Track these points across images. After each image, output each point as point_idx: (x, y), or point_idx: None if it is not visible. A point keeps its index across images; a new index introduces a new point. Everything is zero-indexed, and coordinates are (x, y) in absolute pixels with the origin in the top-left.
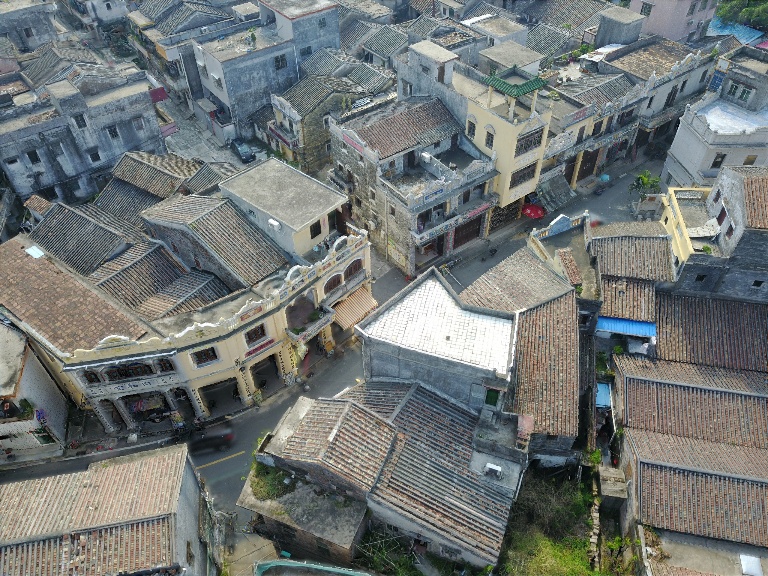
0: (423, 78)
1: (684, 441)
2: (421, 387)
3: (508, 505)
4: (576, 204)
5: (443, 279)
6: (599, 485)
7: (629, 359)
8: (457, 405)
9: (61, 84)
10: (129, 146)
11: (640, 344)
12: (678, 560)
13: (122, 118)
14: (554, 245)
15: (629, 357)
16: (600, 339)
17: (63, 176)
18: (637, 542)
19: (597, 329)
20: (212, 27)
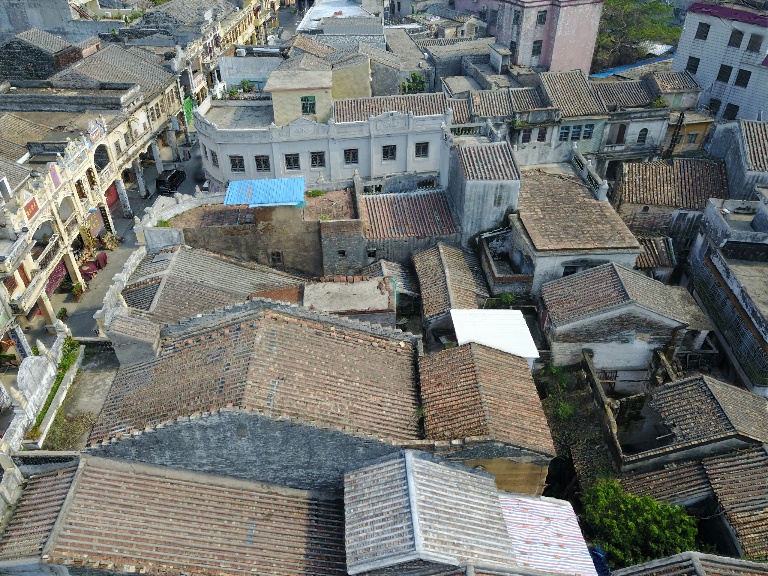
0: None
1: None
2: None
3: None
4: None
5: None
6: None
7: None
8: None
9: None
10: None
11: None
12: None
13: None
14: None
15: None
16: None
17: None
18: (160, 2)
19: None
20: None
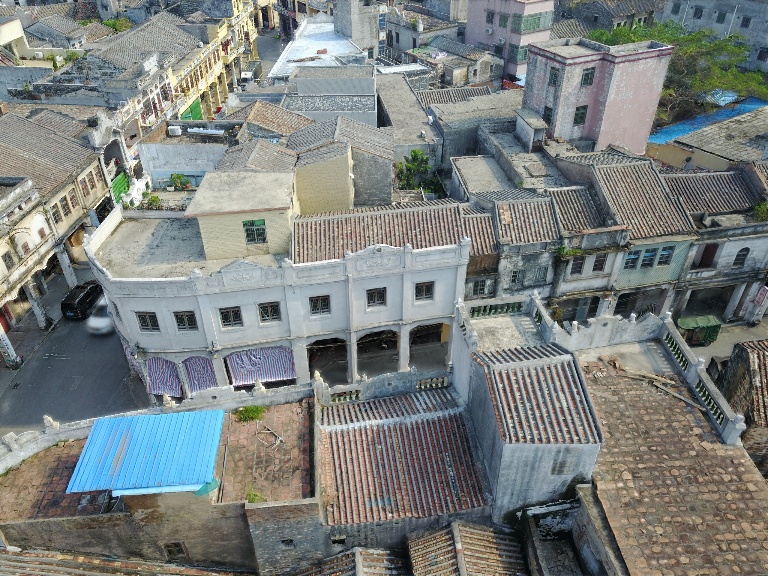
0: None
1: None
2: None
3: (140, 7)
4: None
5: None
6: None
7: None
8: None
9: None
10: None
11: None
12: None
13: None
14: None
15: None
16: None
17: None
18: (121, 29)
19: None
20: None
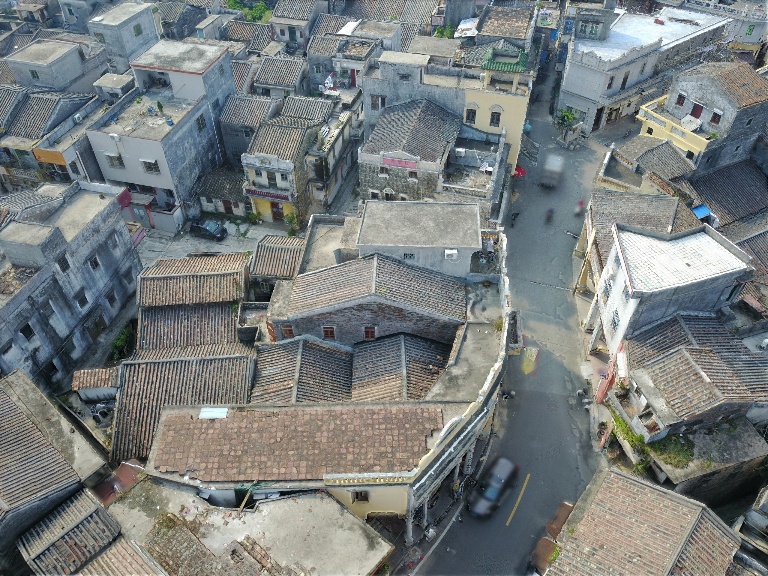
0: (402, 86)
1: None
2: (682, 315)
3: None
4: None
5: (633, 227)
6: None
7: None
8: (703, 316)
9: (13, 229)
10: (109, 272)
11: None
12: None
13: (98, 241)
14: None
15: None
16: None
17: (58, 341)
18: None
19: None
20: (82, 112)
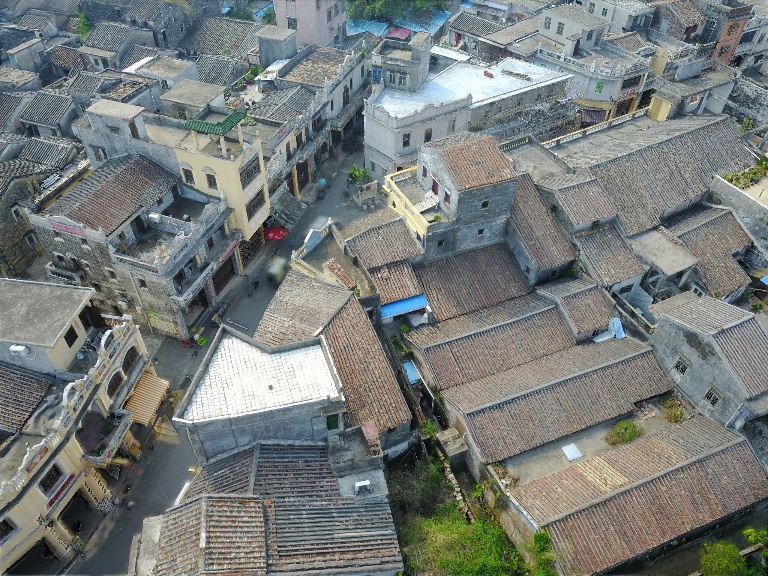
0: (115, 139)
1: (486, 380)
2: (263, 445)
3: (388, 510)
4: (307, 213)
5: (238, 333)
6: (442, 450)
7: (417, 332)
8: (303, 445)
9: None
10: None
11: (419, 316)
12: (526, 477)
13: None
14: (316, 259)
15: (416, 331)
16: (386, 325)
17: None
18: (494, 481)
19: (382, 318)
20: None
